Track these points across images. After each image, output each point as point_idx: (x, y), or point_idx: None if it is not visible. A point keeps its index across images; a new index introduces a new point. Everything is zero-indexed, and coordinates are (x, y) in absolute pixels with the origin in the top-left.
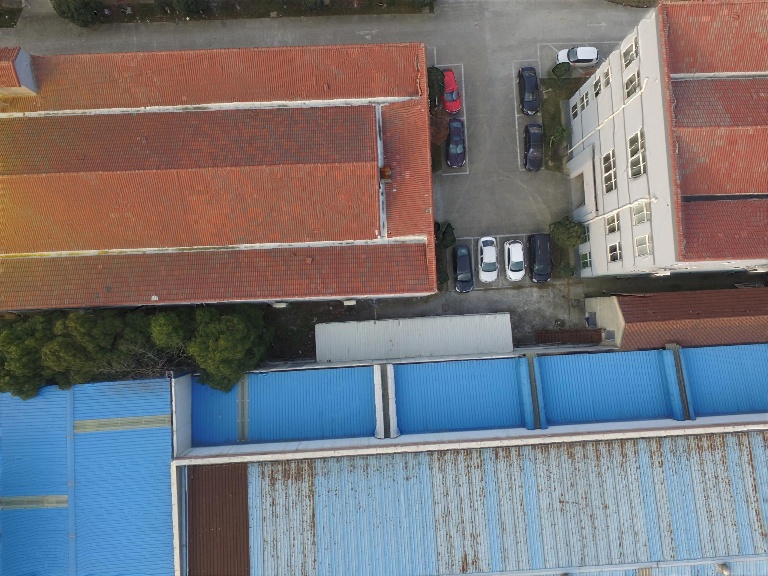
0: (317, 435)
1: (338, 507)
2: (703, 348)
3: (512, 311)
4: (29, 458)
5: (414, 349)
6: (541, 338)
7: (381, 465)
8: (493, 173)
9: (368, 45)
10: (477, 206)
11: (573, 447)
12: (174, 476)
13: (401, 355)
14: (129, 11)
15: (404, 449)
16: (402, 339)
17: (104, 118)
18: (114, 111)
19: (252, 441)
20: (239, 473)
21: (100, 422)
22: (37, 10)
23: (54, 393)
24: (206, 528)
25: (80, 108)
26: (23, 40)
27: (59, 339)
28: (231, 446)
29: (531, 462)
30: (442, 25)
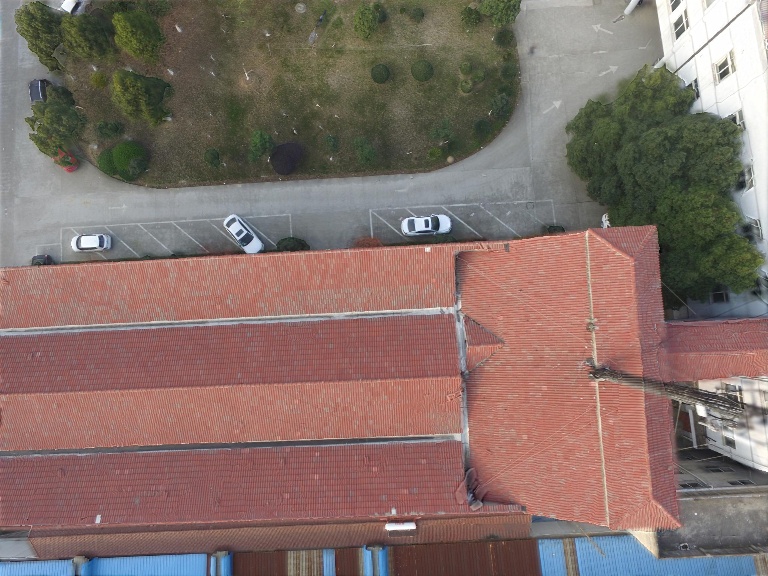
0: None
1: None
2: (121, 558)
3: None
4: None
5: None
6: None
7: None
8: None
9: None
10: None
11: None
12: None
13: None
14: None
15: None
16: None
17: None
18: None
19: None
20: None
21: None
22: None
23: None
24: None
25: None
26: None
27: None
28: None
29: None
30: None
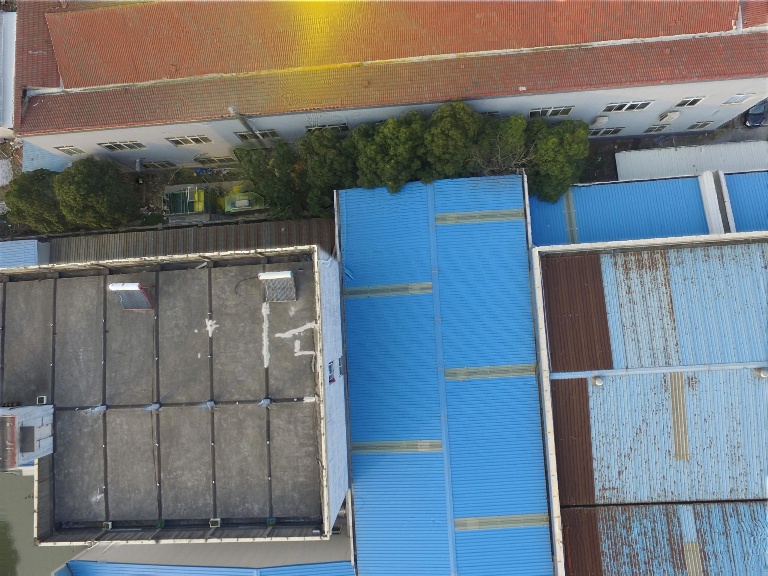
0: None
1: (696, 294)
2: None
3: None
4: (391, 250)
5: None
6: None
7: (736, 254)
8: None
9: None
10: None
11: None
12: (537, 261)
13: None
14: None
15: None
16: (706, 164)
17: None
18: None
19: None
20: (592, 263)
21: (459, 215)
22: None
23: (415, 189)
24: (564, 314)
25: None
26: None
27: (448, 119)
28: None
29: None
30: None
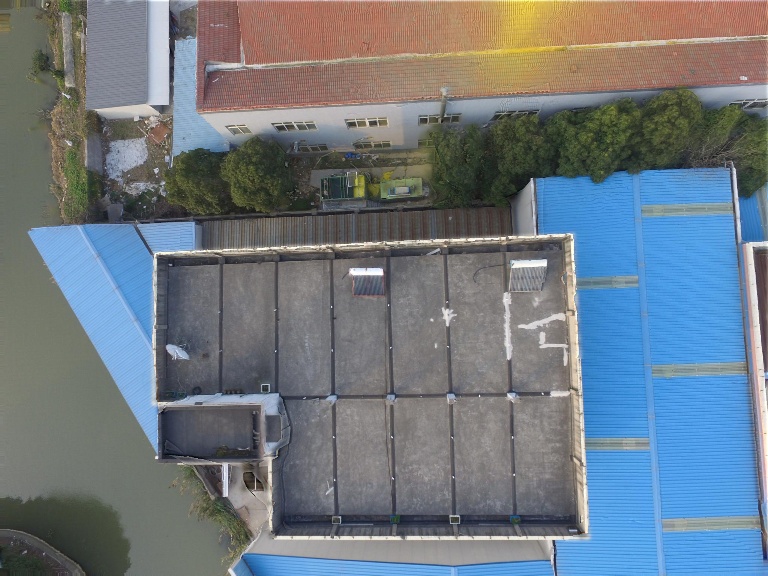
0: None
1: None
2: None
3: None
4: (593, 242)
5: None
6: None
7: None
8: None
9: None
10: None
11: None
12: (751, 257)
13: None
14: None
15: None
16: None
17: None
18: None
19: None
20: None
21: (666, 207)
22: None
23: (619, 179)
24: None
25: None
26: None
27: (674, 107)
28: None
29: None
30: None
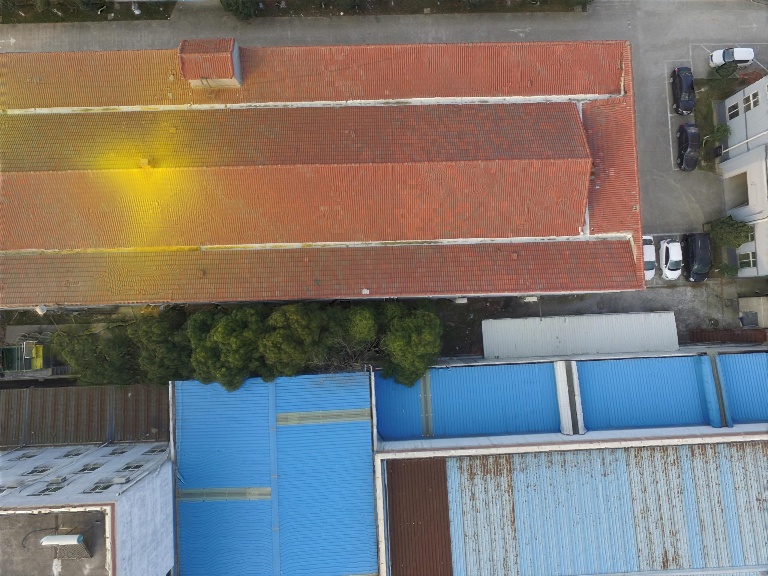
0: (501, 431)
1: (537, 502)
2: None
3: (667, 310)
4: (230, 450)
5: (580, 346)
6: (697, 337)
7: (578, 461)
8: (647, 172)
9: (574, 42)
10: None
11: (767, 445)
12: (379, 470)
13: (568, 352)
14: (283, 5)
15: (607, 445)
16: (569, 336)
17: (307, 111)
18: (316, 104)
19: (438, 436)
20: (438, 467)
21: (302, 415)
22: (191, 3)
23: (256, 385)
24: (407, 522)
25: (282, 101)
26: (177, 32)
27: (280, 331)
28: (419, 441)
29: (727, 460)
30: (595, 24)
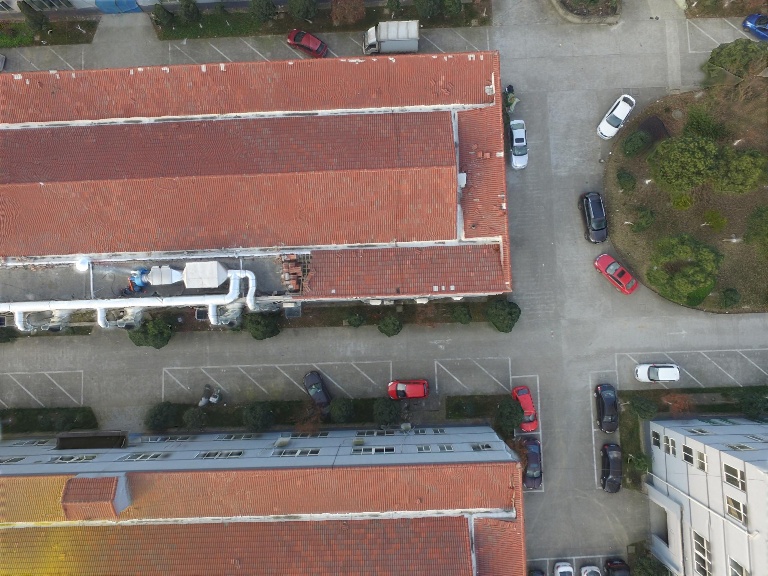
0: None
1: None
2: None
3: None
4: None
5: None
6: None
7: None
8: (569, 491)
9: (462, 466)
10: (553, 526)
11: None
12: None
13: None
14: None
15: None
16: None
17: (196, 529)
18: (205, 519)
19: None
20: None
21: None
22: None
23: None
24: None
25: (172, 517)
26: (98, 348)
27: None
28: None
29: None
30: (517, 334)
